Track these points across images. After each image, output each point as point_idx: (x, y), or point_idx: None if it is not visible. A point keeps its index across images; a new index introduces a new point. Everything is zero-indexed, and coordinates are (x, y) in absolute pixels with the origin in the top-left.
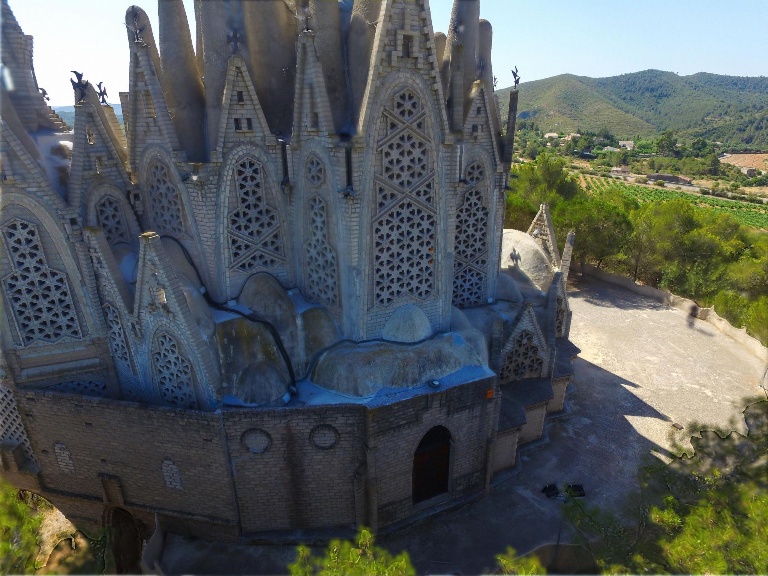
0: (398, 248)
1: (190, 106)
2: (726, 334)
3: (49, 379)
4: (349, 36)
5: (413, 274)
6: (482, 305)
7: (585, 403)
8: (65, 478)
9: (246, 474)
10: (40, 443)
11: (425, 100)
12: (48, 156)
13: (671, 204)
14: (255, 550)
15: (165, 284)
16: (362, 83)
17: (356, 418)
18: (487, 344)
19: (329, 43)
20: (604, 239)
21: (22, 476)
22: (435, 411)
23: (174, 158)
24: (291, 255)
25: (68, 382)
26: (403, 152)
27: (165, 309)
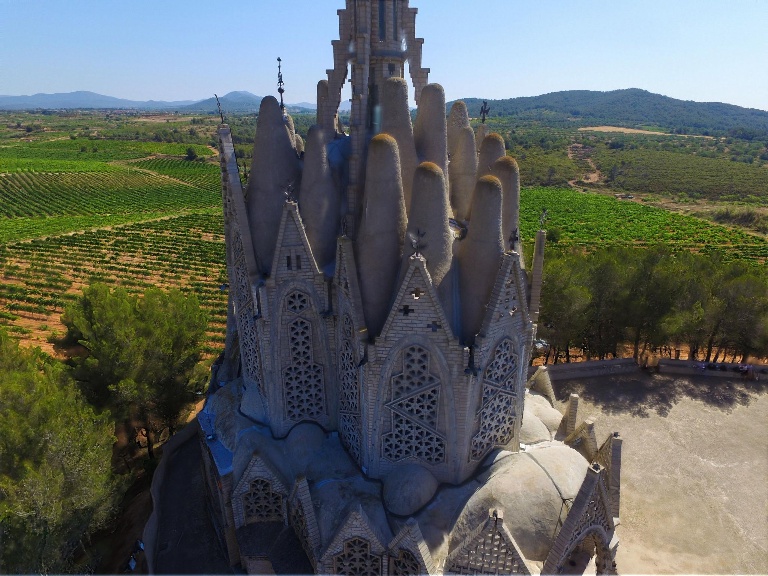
0: None
1: None
2: None
3: None
4: None
5: None
6: (358, 466)
7: None
8: None
9: None
10: None
11: None
12: None
13: None
14: None
15: None
16: None
17: None
18: None
19: None
20: None
21: None
22: None
23: None
24: None
25: None
26: None
27: None
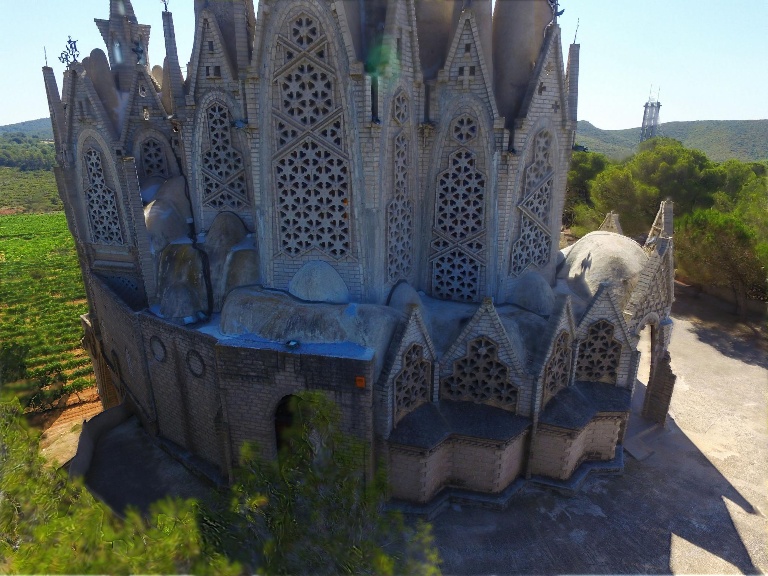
0: (304, 193)
1: None
2: None
3: (108, 271)
4: None
5: (324, 226)
6: (477, 303)
7: (622, 491)
8: None
9: (157, 379)
10: None
11: (326, 24)
12: (125, 107)
13: None
14: (159, 453)
15: None
16: None
17: (214, 352)
18: (393, 328)
19: None
20: None
21: None
22: (290, 376)
23: (175, 104)
24: None
25: (118, 277)
26: (304, 85)
27: None
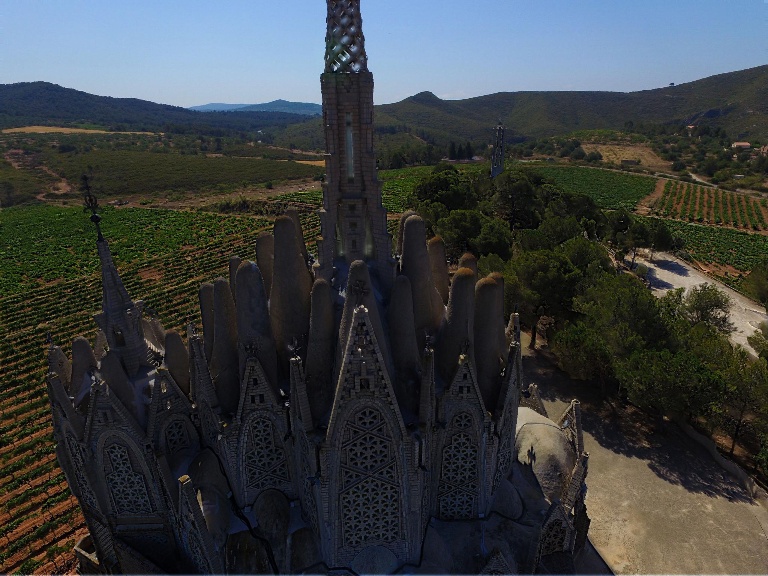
0: (364, 508)
1: (230, 367)
2: None
3: (132, 533)
4: None
5: (379, 525)
6: (473, 519)
7: None
8: None
9: None
10: (125, 571)
11: (385, 413)
12: (140, 395)
13: None
14: None
15: None
16: None
17: None
18: None
19: (320, 352)
20: (683, 400)
21: None
22: None
23: (212, 412)
24: (295, 477)
25: (144, 535)
26: (366, 447)
27: (193, 525)
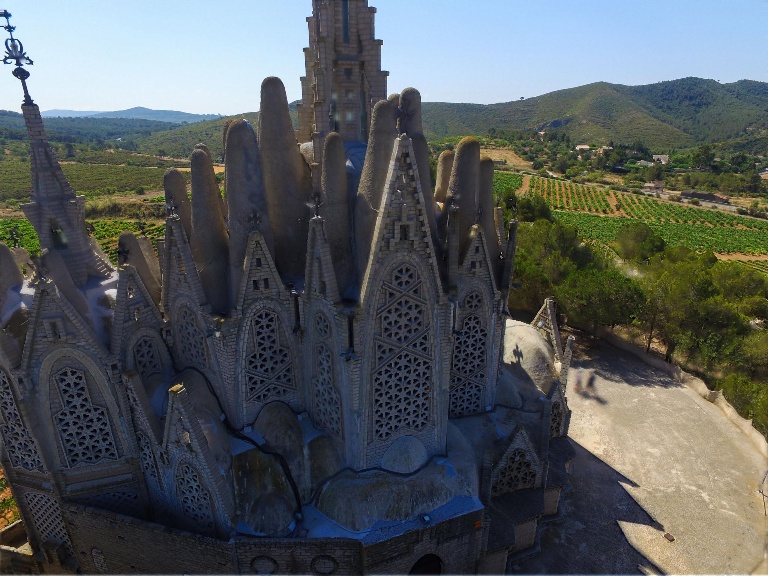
0: (396, 391)
1: (216, 260)
2: (733, 422)
3: (89, 492)
4: (355, 208)
5: (410, 410)
6: (481, 413)
7: (580, 504)
8: (100, 575)
9: None
10: (80, 546)
11: (421, 270)
12: (95, 307)
13: (688, 268)
14: None
15: (189, 429)
16: (365, 257)
17: (353, 551)
18: (478, 472)
19: (337, 216)
20: (615, 311)
21: (64, 569)
22: (425, 542)
23: (201, 311)
24: (301, 384)
25: (105, 494)
26: (401, 314)
27: (189, 448)
